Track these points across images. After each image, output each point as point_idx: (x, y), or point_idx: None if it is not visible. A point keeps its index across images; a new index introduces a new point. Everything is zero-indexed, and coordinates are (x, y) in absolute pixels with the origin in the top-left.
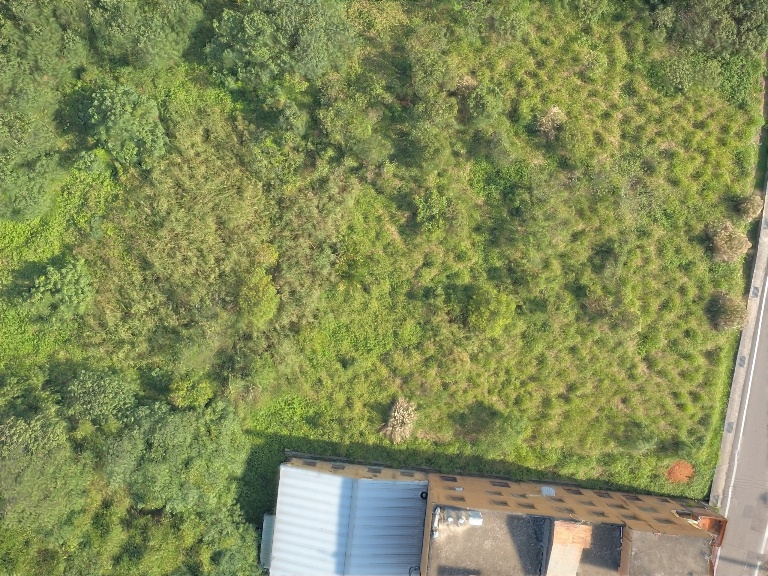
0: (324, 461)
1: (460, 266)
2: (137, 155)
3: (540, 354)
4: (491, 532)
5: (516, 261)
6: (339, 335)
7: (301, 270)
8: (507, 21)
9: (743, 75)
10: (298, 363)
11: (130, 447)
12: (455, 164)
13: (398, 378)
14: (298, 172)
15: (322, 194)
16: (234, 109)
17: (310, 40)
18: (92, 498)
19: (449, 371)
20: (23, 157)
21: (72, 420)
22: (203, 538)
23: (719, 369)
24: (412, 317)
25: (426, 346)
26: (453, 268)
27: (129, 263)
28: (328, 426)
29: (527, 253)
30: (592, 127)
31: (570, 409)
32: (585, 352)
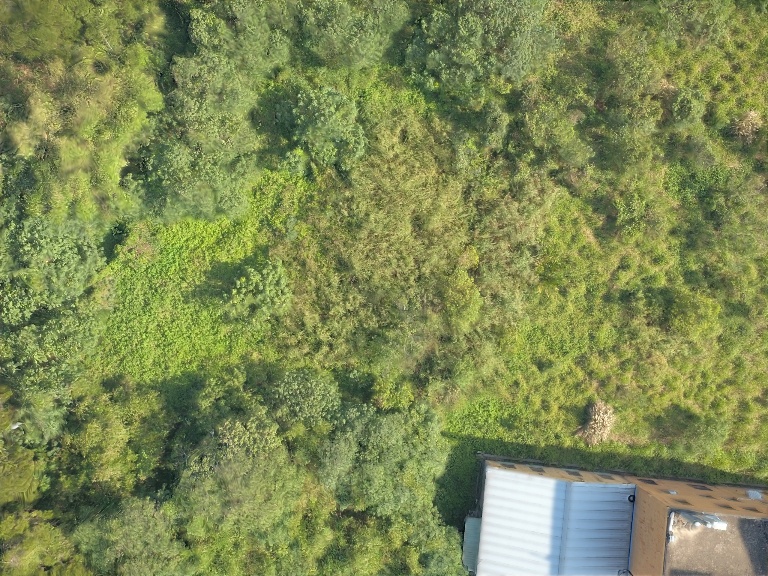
0: (519, 464)
1: (655, 269)
2: (336, 156)
3: (736, 358)
4: (722, 536)
5: (712, 265)
6: (534, 338)
7: (501, 273)
8: (711, 25)
9: None
10: (493, 366)
11: (347, 450)
12: (651, 167)
13: (594, 381)
14: (496, 174)
15: (522, 197)
16: (428, 110)
17: (520, 42)
18: (298, 500)
19: (647, 374)
20: (227, 157)
21: (279, 422)
22: (409, 541)
23: None
24: (608, 320)
25: (623, 349)
26: (650, 271)
27: (324, 264)
28: (523, 429)
29: (723, 257)
30: None
31: (767, 413)
32: None
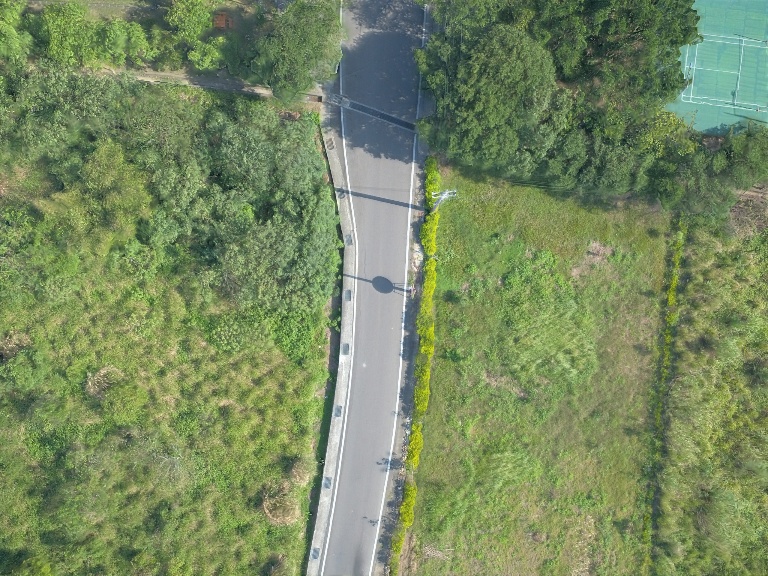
0: None
1: (15, 529)
2: None
3: None
4: None
5: None
6: None
7: None
8: (44, 286)
9: (303, 329)
10: None
11: None
12: (8, 424)
13: None
14: None
15: None
16: None
17: None
18: None
19: None
20: None
21: None
22: None
23: None
24: None
25: None
26: (5, 533)
27: None
28: None
29: None
30: (148, 385)
31: None
32: None
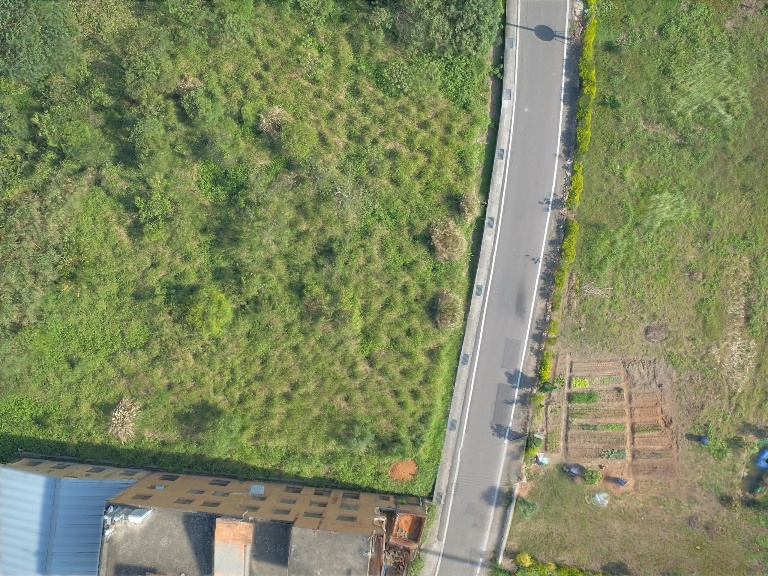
0: (53, 461)
1: (187, 266)
2: None
3: (265, 353)
4: (168, 530)
5: (241, 261)
6: (67, 336)
7: (24, 271)
8: (224, 23)
9: (467, 75)
10: (27, 364)
11: None
12: (182, 165)
13: (124, 378)
14: (23, 174)
15: (45, 196)
16: None
17: (20, 44)
18: None
19: (172, 371)
20: None
21: None
22: None
23: (440, 367)
24: (138, 317)
25: (151, 346)
26: (178, 268)
27: None
28: (57, 426)
29: None
30: (317, 128)
31: (292, 408)
32: (307, 351)
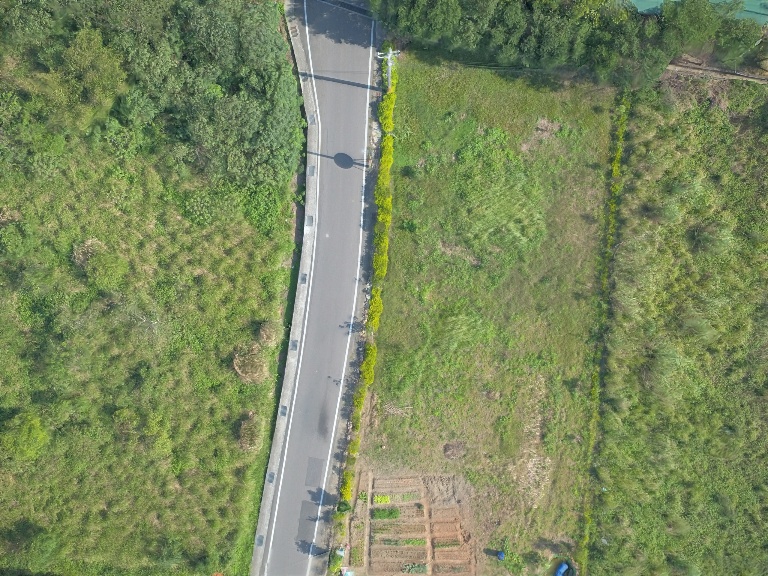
0: None
1: (9, 390)
2: None
3: (81, 473)
4: None
5: (58, 385)
6: None
7: None
8: (33, 162)
9: (270, 203)
10: None
11: None
12: (2, 294)
13: None
14: None
15: None
16: None
17: None
18: None
19: None
20: None
21: None
22: None
23: (245, 486)
24: None
25: None
26: None
27: None
28: None
29: None
30: (129, 256)
31: (106, 526)
32: (120, 471)
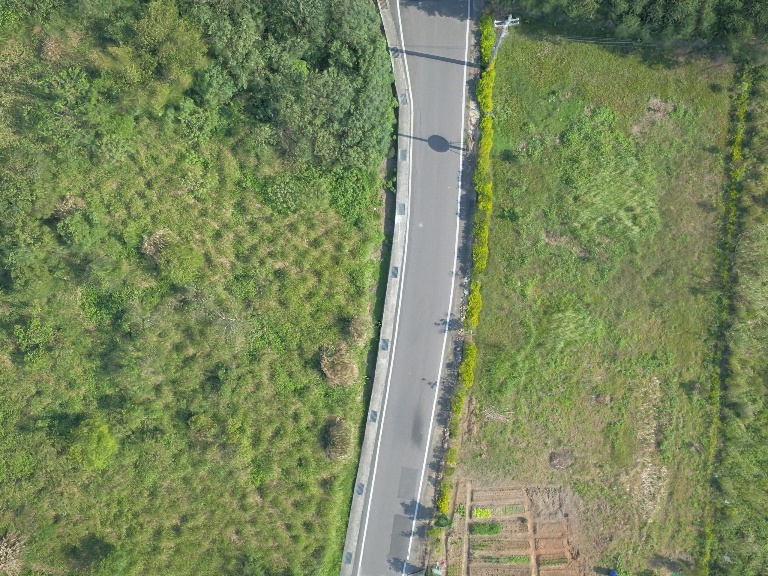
0: None
1: (72, 394)
2: None
3: (152, 484)
4: None
5: (126, 388)
6: None
7: None
8: (101, 145)
9: (358, 190)
10: None
11: None
12: (65, 289)
13: (9, 511)
14: None
15: None
16: None
17: None
18: None
19: None
20: None
21: None
22: None
23: (333, 498)
24: (22, 448)
25: (36, 478)
26: (62, 397)
27: None
28: None
29: None
30: (204, 248)
31: (180, 542)
32: (195, 482)
